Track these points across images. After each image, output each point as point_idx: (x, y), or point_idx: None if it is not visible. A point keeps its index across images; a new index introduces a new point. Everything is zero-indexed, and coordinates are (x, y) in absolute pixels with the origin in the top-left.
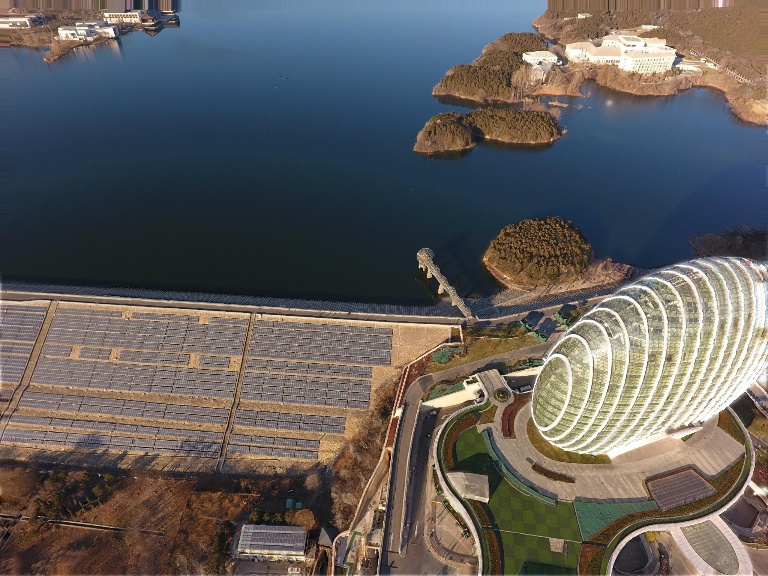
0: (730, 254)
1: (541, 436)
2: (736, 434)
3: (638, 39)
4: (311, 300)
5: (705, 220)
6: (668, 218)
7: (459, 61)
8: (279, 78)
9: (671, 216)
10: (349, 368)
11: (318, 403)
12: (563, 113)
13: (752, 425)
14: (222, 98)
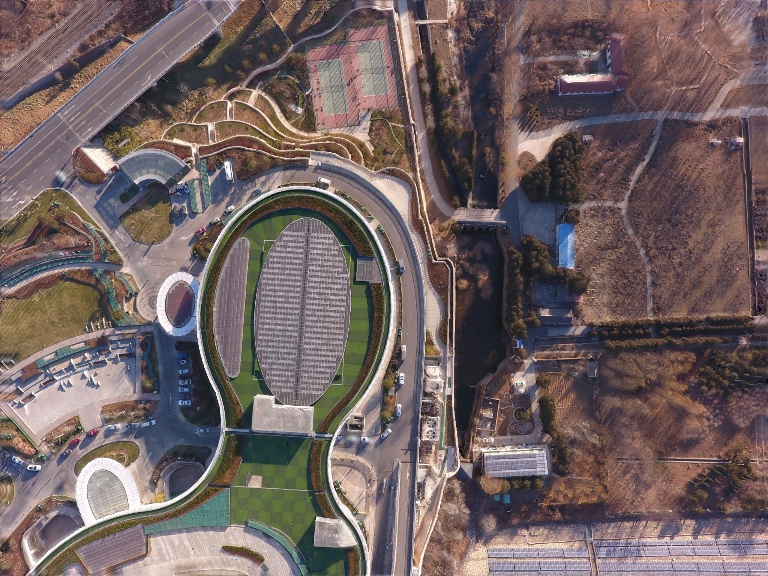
0: None
1: None
2: None
3: None
4: None
5: None
6: None
7: None
8: None
9: None
10: None
11: None
12: None
13: None
14: None
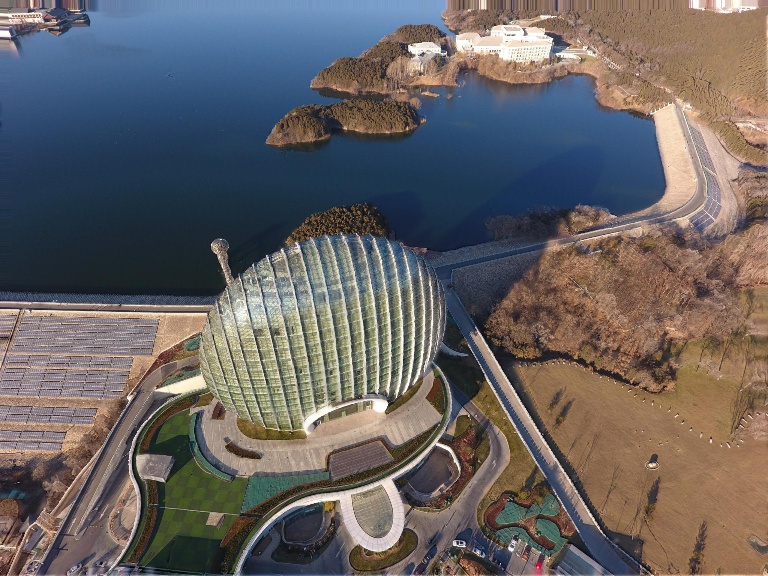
0: (524, 234)
1: None
2: (439, 405)
3: (519, 28)
4: (94, 294)
5: (517, 203)
6: None
7: (342, 54)
8: (162, 75)
9: (490, 200)
10: (110, 359)
11: (74, 395)
12: (432, 103)
13: (476, 396)
14: (78, 96)
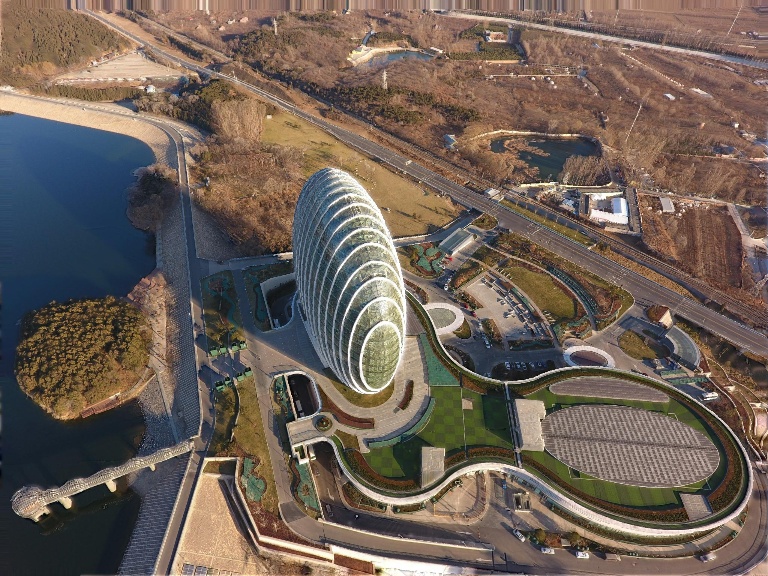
0: (161, 211)
1: (370, 397)
2: None
3: None
4: None
5: (101, 208)
6: (79, 229)
7: None
8: None
9: (76, 226)
10: None
11: None
12: None
13: None
14: None
